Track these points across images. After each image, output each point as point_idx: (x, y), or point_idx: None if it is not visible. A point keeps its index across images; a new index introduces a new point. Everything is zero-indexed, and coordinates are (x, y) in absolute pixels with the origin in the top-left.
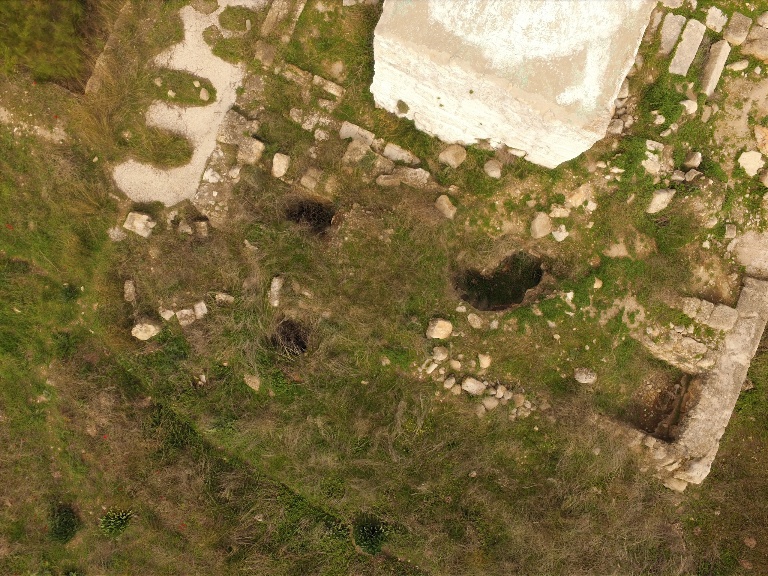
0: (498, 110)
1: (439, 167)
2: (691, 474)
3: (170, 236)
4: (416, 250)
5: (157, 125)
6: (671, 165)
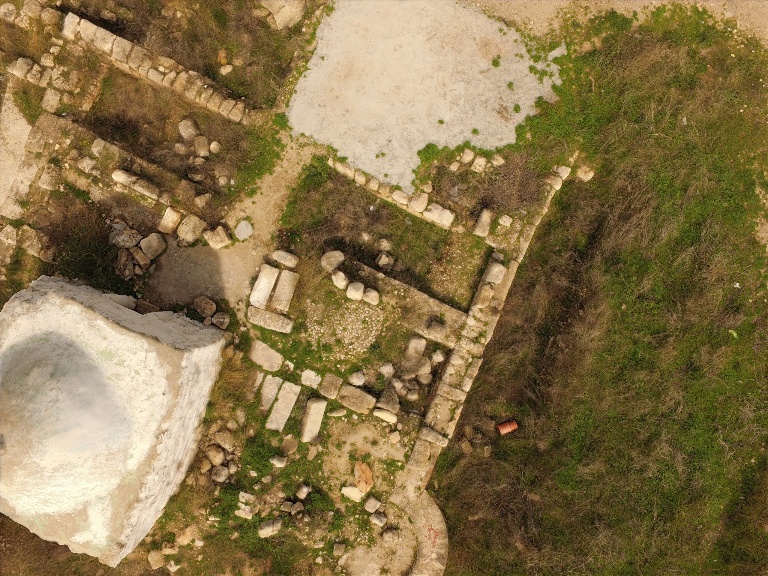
0: None
1: None
2: None
3: None
4: None
5: None
6: (281, 497)
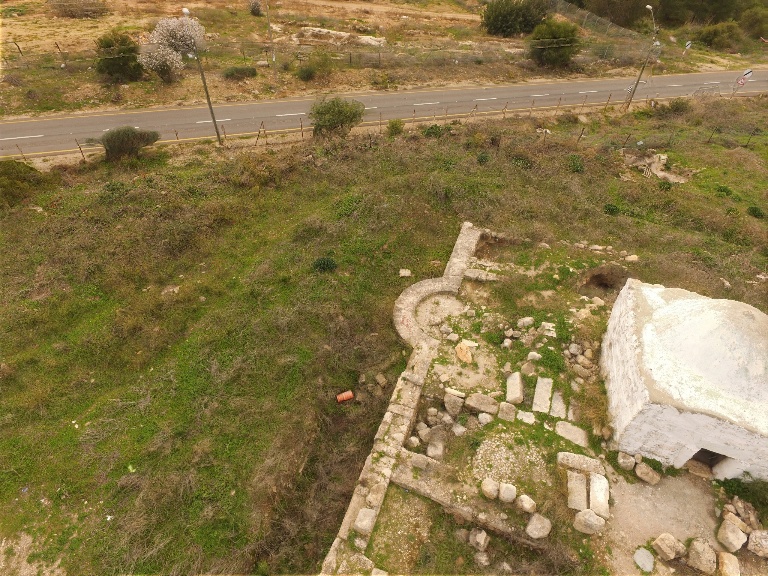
0: None
1: None
2: None
3: None
4: None
5: None
6: None
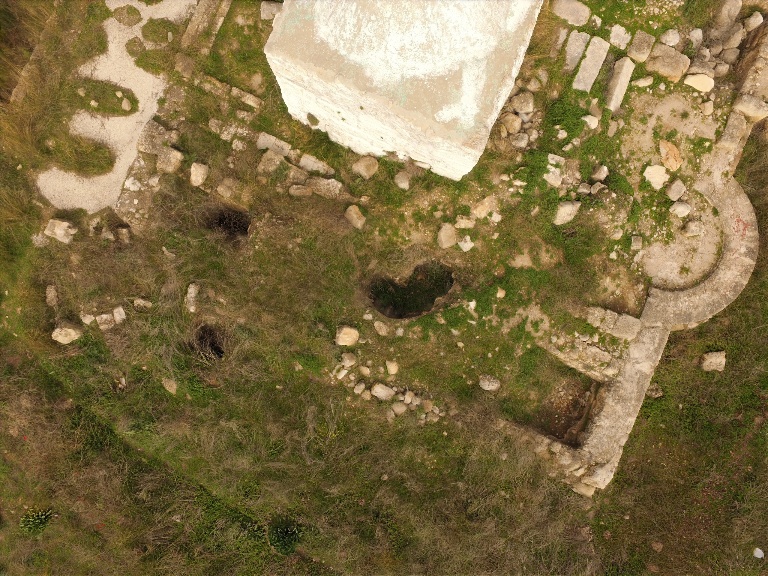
0: (390, 125)
1: (351, 178)
2: (595, 479)
3: (92, 242)
4: (323, 259)
5: (80, 134)
6: (578, 178)
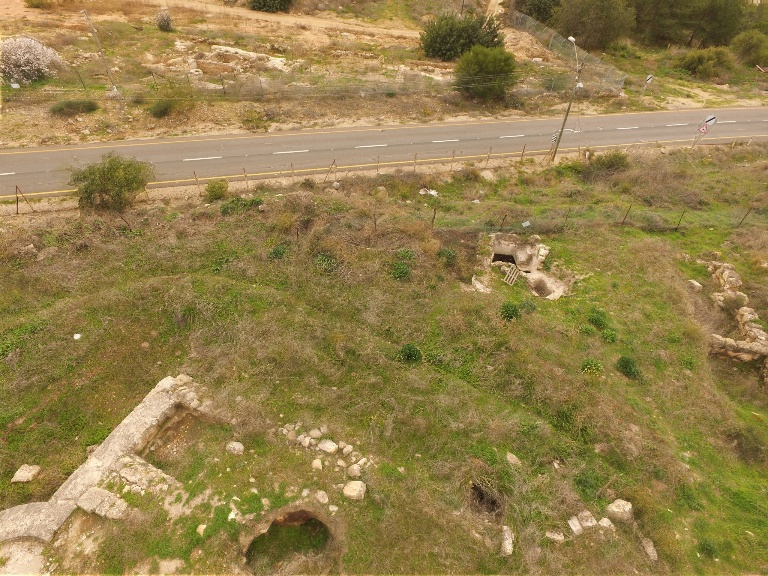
0: None
1: None
2: (173, 381)
3: None
4: (373, 569)
5: None
6: None
